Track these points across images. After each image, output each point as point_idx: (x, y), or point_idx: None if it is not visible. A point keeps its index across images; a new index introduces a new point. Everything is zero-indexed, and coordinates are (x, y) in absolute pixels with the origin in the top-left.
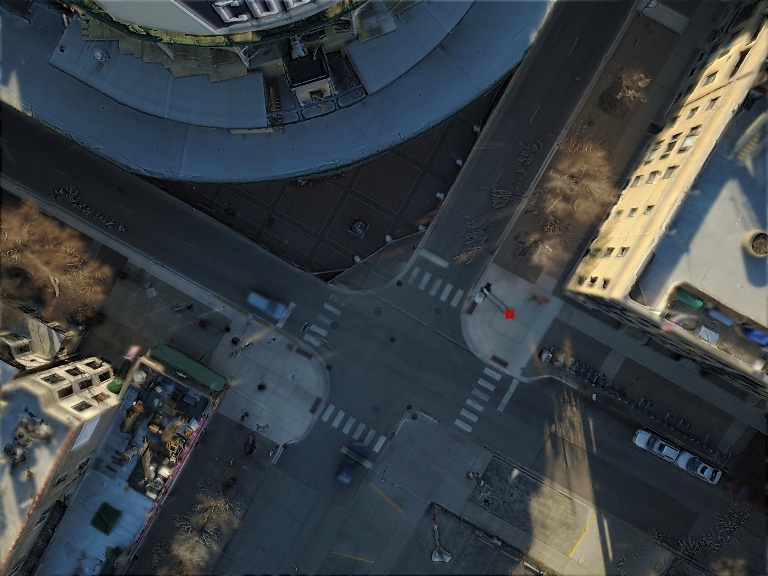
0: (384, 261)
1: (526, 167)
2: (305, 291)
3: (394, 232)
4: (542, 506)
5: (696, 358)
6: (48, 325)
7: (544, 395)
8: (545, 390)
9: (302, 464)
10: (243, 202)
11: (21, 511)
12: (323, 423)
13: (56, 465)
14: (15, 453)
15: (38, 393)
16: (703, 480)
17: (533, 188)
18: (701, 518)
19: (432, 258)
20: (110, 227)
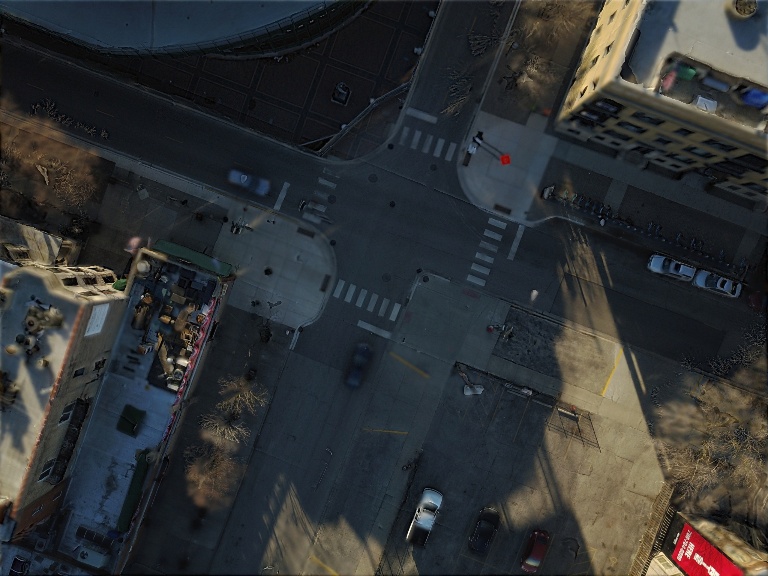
0: (372, 126)
1: (499, 9)
2: (297, 169)
3: (377, 95)
4: (567, 349)
5: (698, 165)
6: (44, 232)
7: (552, 237)
8: (552, 231)
9: (320, 345)
10: (222, 88)
11: (43, 403)
12: (335, 300)
13: (71, 348)
14: (28, 343)
15: (42, 277)
16: (724, 297)
17: (509, 29)
18: (728, 336)
19: (419, 116)
20: (92, 135)
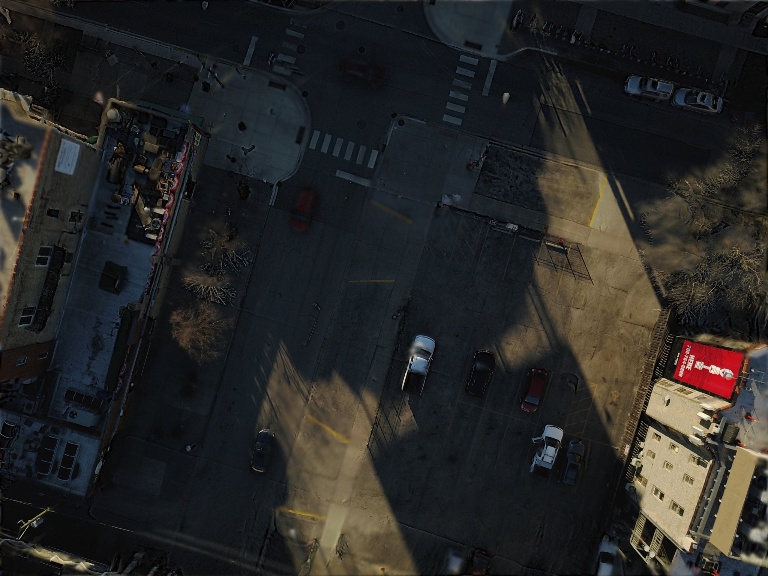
0: None
1: None
2: (264, 22)
3: None
4: (550, 181)
5: None
6: (13, 92)
7: (525, 69)
8: (525, 64)
9: (300, 198)
10: None
11: (17, 238)
12: (312, 151)
13: (41, 177)
14: None
15: (7, 106)
16: (705, 114)
17: None
18: (713, 155)
19: None
20: (59, 5)
